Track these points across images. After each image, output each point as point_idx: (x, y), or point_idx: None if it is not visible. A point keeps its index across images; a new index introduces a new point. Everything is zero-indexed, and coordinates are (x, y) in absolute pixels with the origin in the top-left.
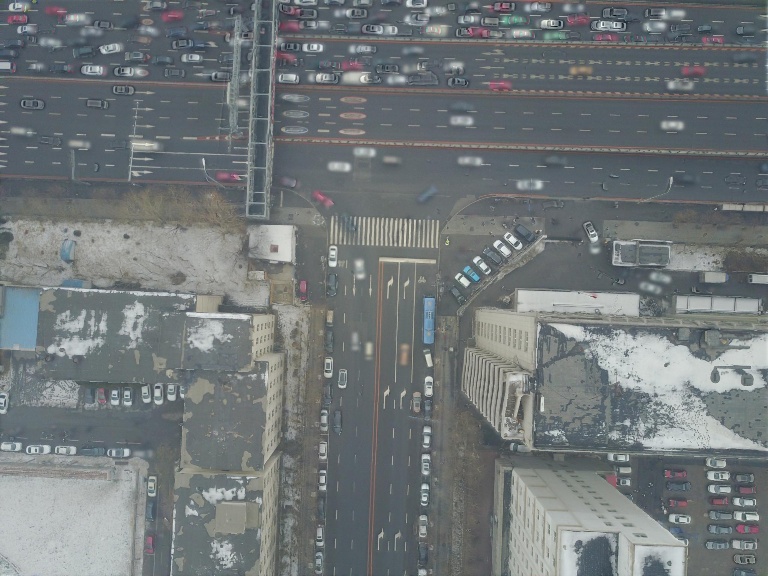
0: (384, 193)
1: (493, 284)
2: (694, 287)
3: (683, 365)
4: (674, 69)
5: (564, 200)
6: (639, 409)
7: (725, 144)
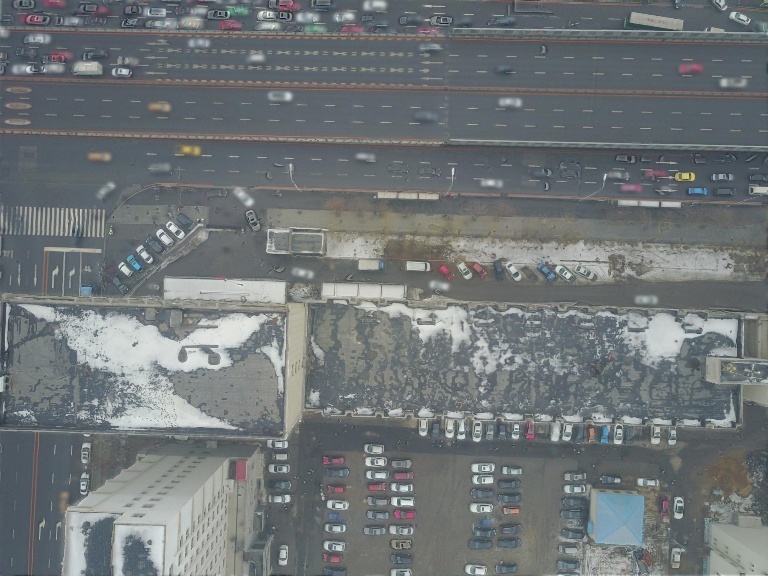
0: (50, 183)
1: (156, 273)
2: (351, 274)
3: (151, 345)
4: (332, 58)
5: (229, 189)
6: (107, 389)
7: (381, 133)
